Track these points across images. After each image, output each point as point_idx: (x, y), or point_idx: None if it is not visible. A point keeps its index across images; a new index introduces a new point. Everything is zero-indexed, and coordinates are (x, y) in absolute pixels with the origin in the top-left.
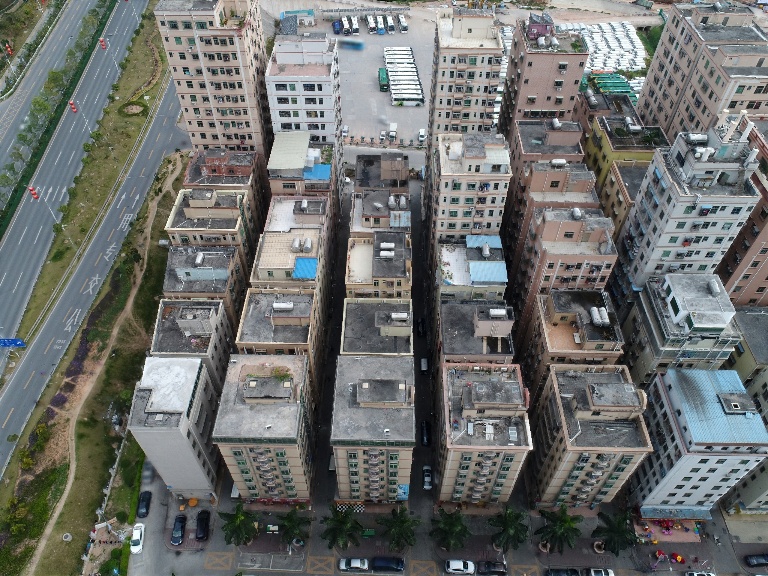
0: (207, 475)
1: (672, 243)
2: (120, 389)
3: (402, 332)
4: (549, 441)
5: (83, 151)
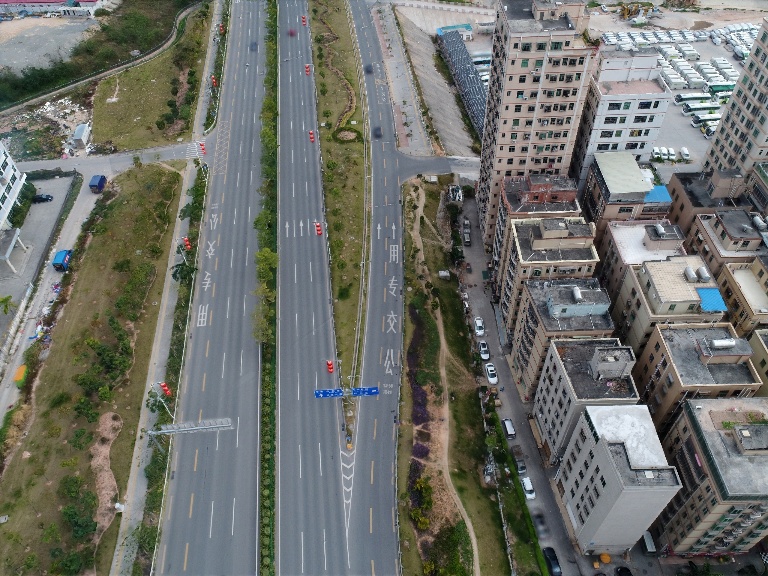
0: None
1: None
2: (472, 435)
3: None
4: None
5: (316, 181)
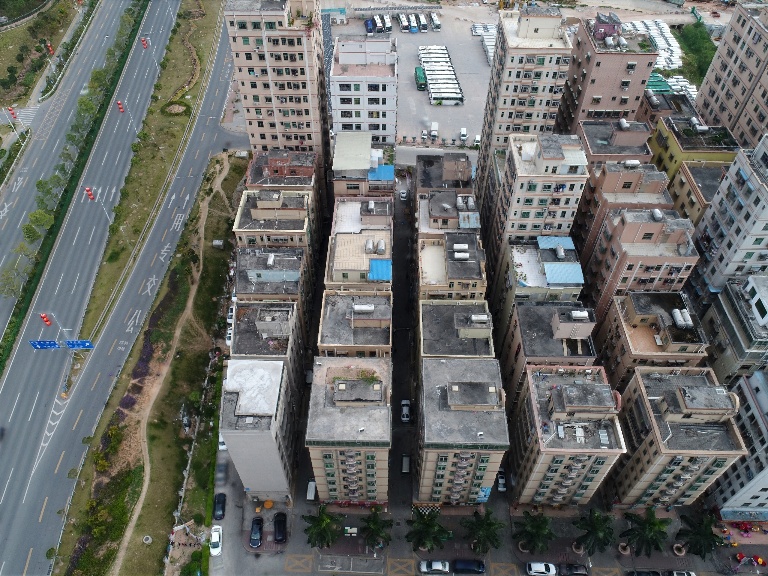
0: (286, 477)
1: (756, 245)
2: (186, 391)
3: (481, 334)
4: (635, 444)
5: (129, 151)
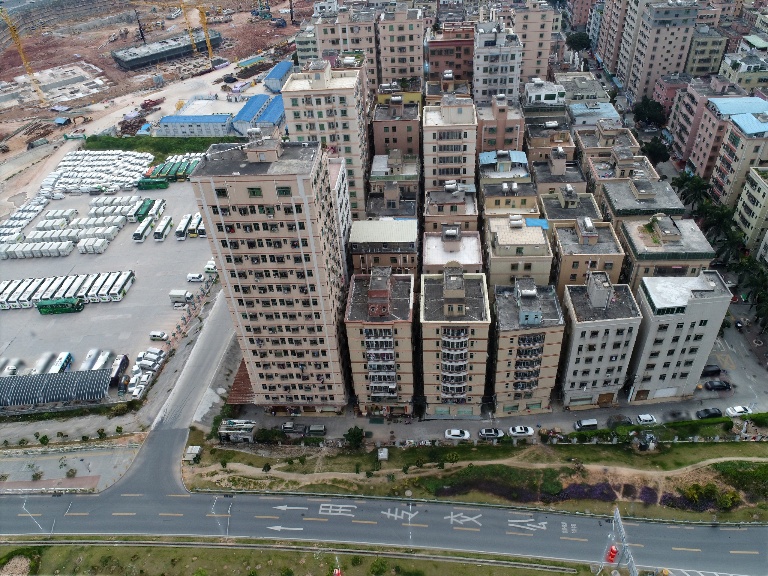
0: None
1: None
2: (607, 453)
3: None
4: None
5: None
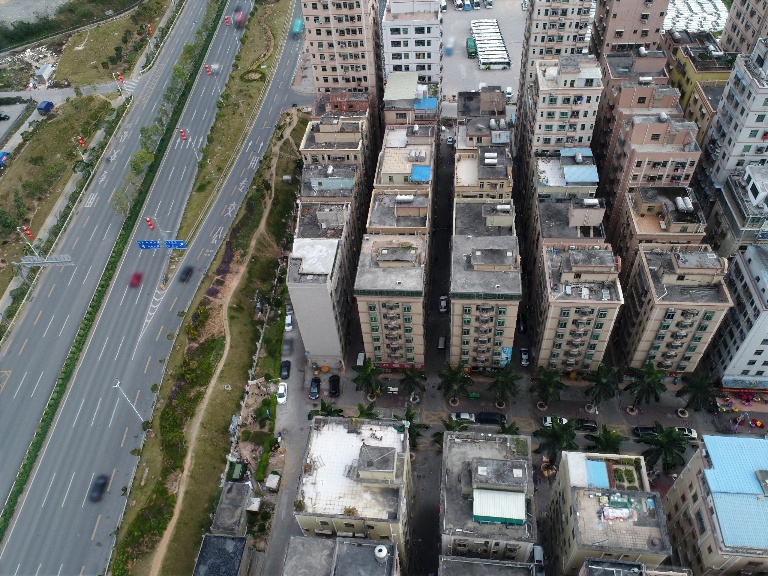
0: (340, 341)
1: (752, 137)
2: (260, 286)
3: (505, 222)
4: (637, 309)
5: (214, 110)
